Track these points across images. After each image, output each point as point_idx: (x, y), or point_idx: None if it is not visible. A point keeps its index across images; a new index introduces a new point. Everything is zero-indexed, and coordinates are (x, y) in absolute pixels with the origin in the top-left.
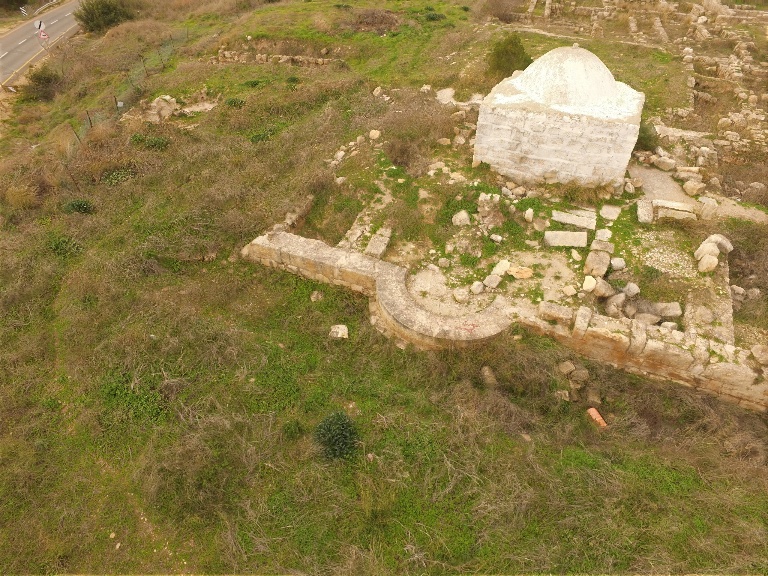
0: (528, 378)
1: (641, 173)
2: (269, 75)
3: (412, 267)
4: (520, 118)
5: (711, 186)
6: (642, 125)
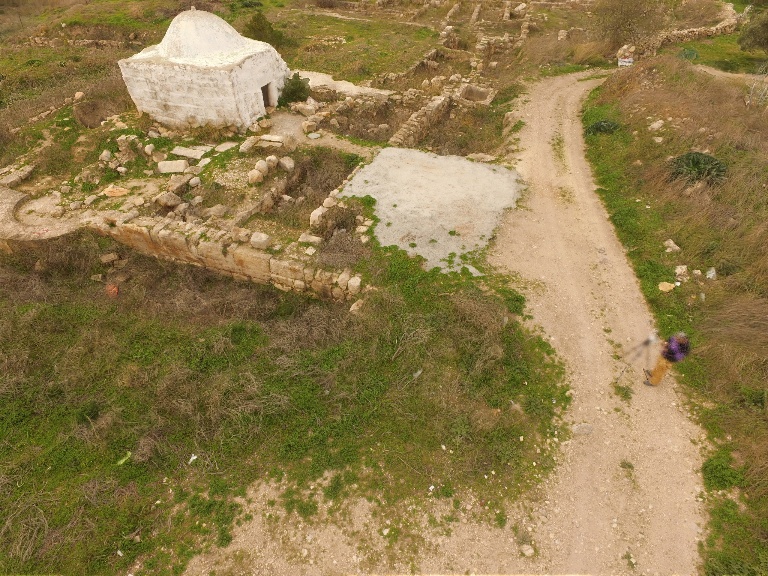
0: (49, 260)
1: (283, 118)
2: (54, 55)
3: (37, 194)
4: (146, 70)
5: (329, 125)
6: (294, 79)
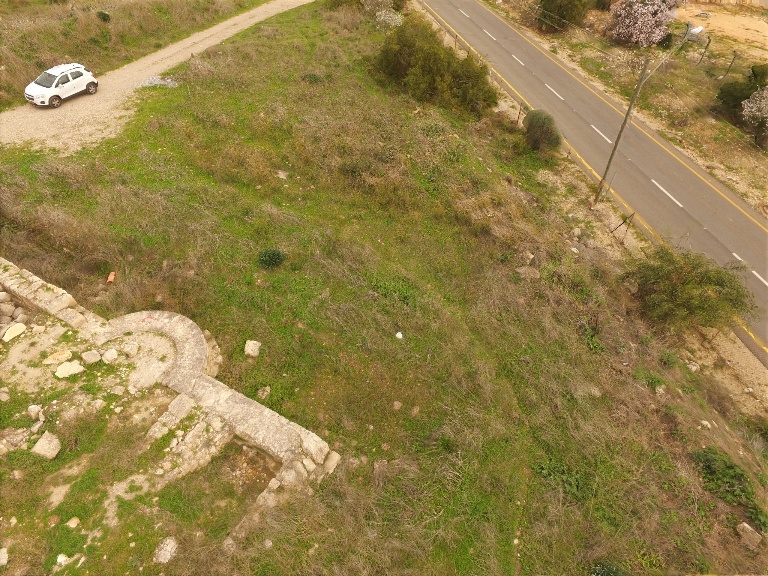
0: None
1: None
2: None
3: (154, 390)
4: None
5: None
6: None
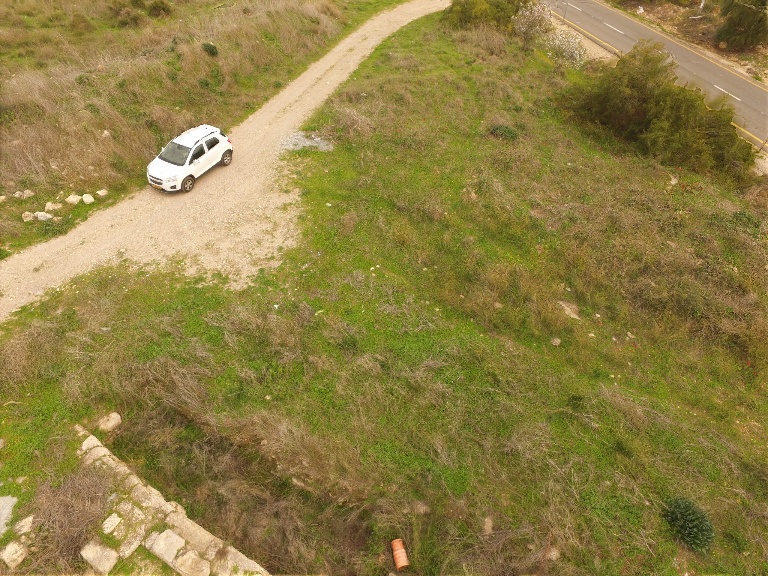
0: None
1: None
2: None
3: None
4: None
5: None
6: None
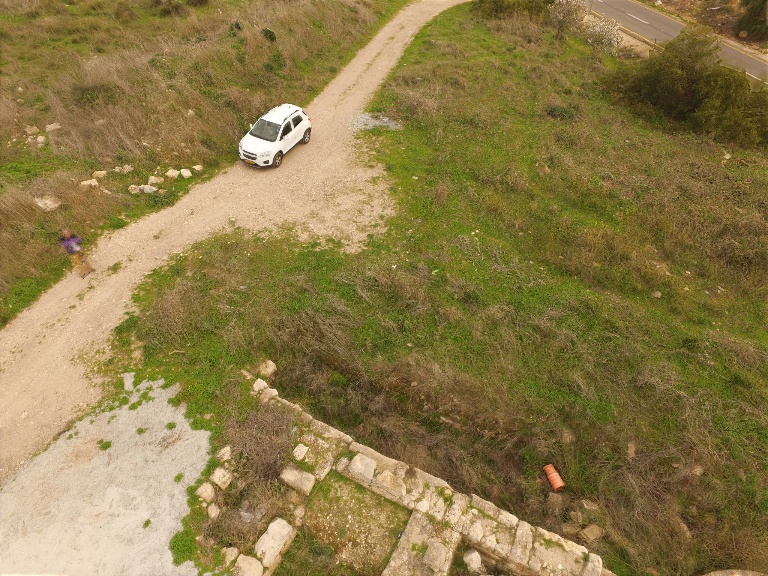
0: None
1: None
2: None
3: None
4: None
5: None
6: None
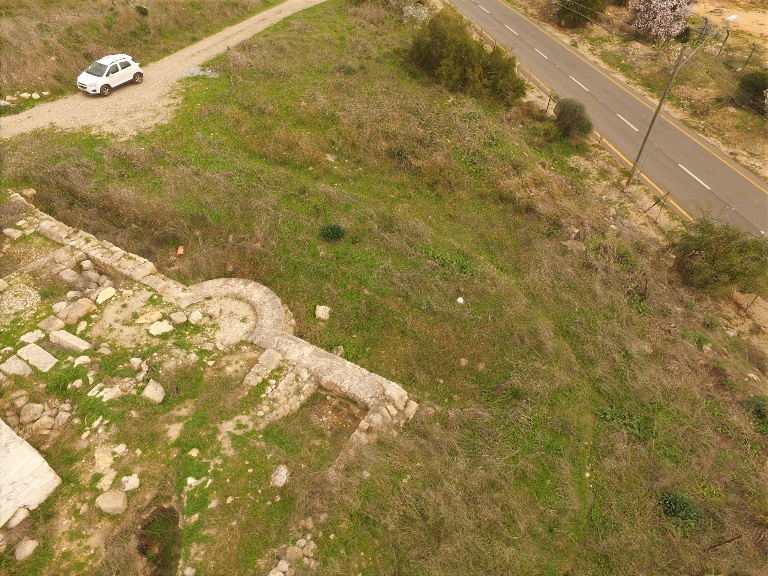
0: None
1: None
2: None
3: None
4: None
5: None
6: None
